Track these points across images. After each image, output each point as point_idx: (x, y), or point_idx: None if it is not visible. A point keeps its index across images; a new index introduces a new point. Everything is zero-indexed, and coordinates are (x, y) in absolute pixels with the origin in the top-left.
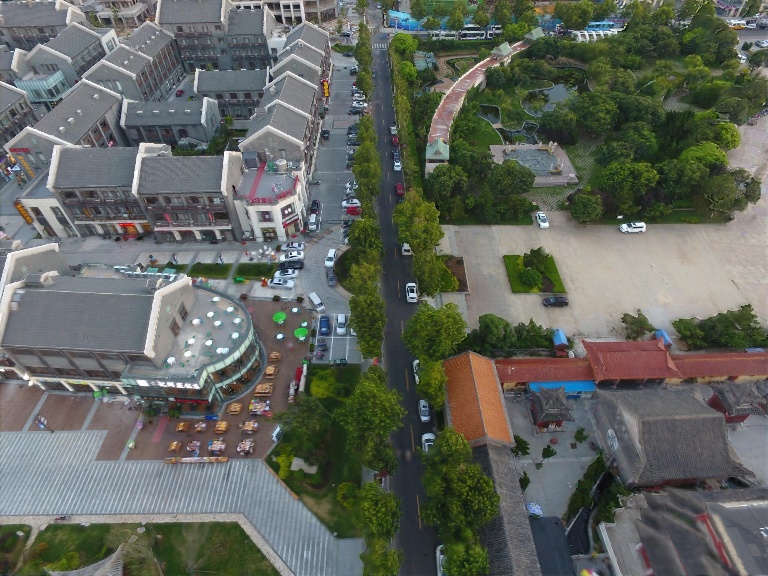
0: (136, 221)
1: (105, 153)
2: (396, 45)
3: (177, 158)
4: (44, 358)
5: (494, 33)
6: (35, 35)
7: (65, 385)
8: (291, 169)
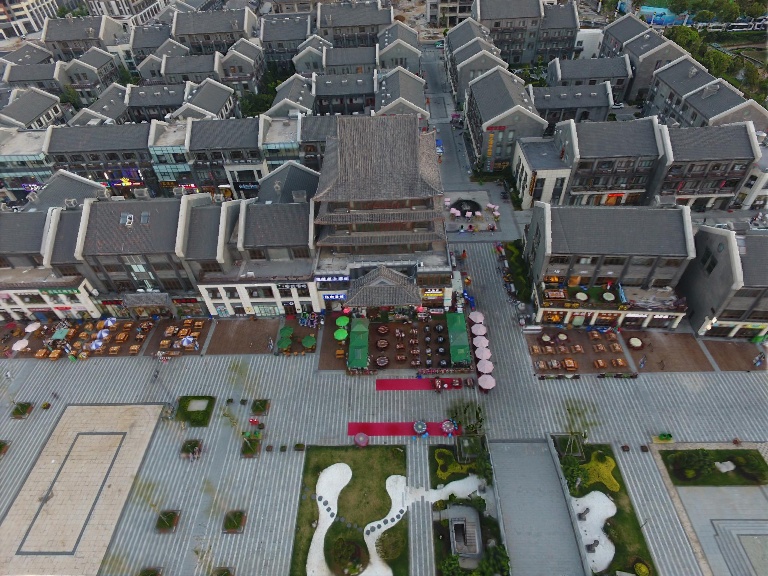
0: (632, 191)
1: (618, 126)
2: (681, 37)
3: (699, 128)
4: (762, 300)
5: (763, 24)
6: (356, 34)
7: (735, 330)
8: (765, 141)
